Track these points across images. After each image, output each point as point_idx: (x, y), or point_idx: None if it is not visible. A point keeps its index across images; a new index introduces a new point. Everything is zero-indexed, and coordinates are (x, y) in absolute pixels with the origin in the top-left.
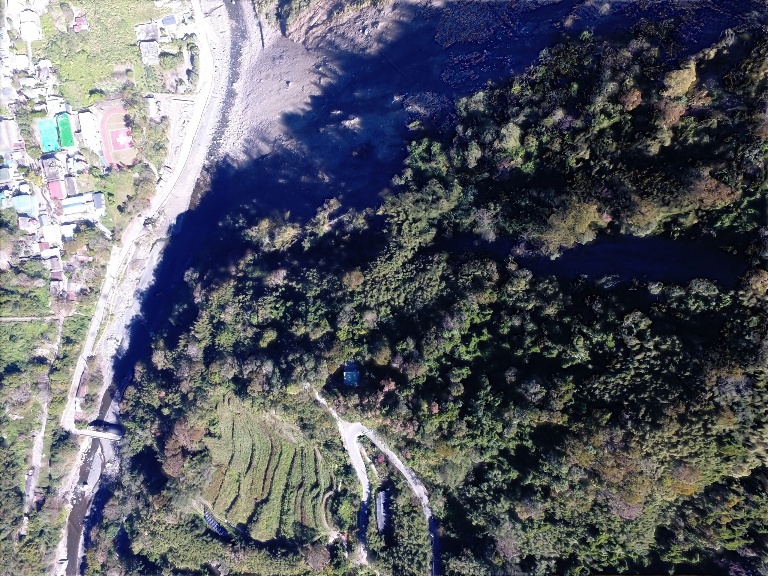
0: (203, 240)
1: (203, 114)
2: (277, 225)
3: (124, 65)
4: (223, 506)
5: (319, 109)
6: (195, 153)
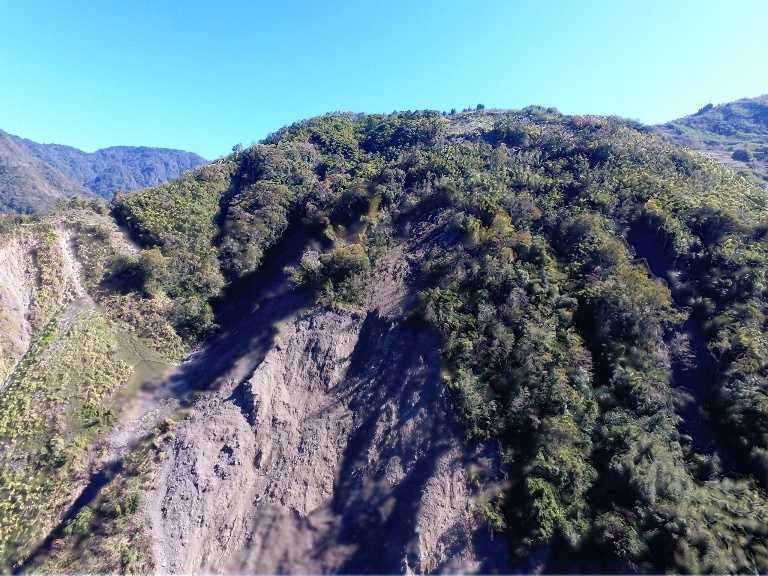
0: None
1: None
2: None
3: None
4: None
5: None
6: None
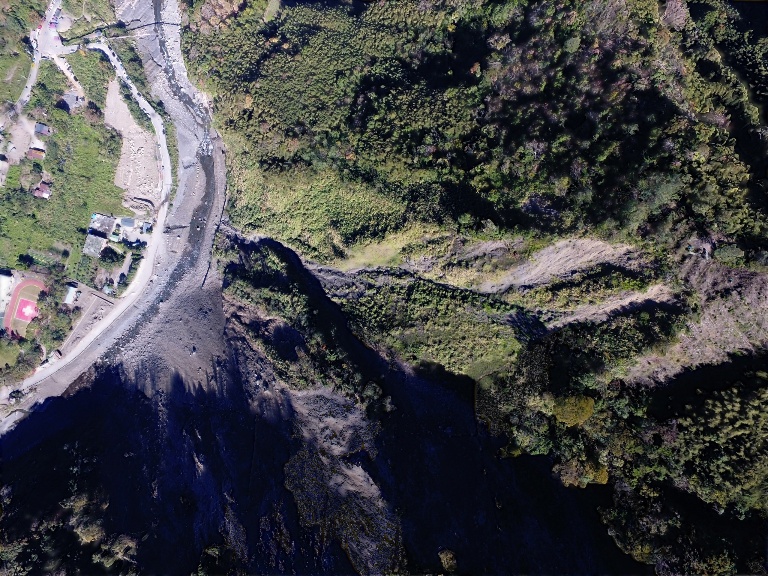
0: (58, 432)
1: (117, 319)
2: (96, 504)
3: (64, 245)
4: None
5: (198, 404)
6: (91, 350)
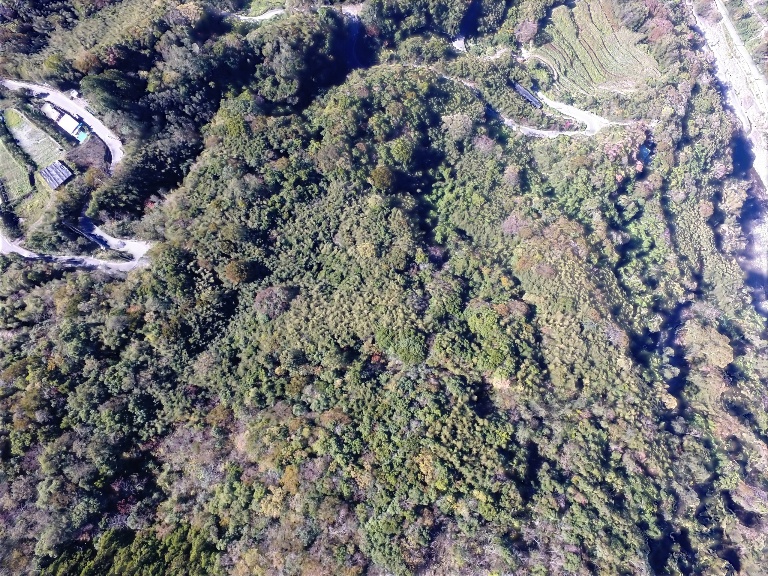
0: None
1: None
2: None
3: None
4: (594, 7)
5: None
6: None
